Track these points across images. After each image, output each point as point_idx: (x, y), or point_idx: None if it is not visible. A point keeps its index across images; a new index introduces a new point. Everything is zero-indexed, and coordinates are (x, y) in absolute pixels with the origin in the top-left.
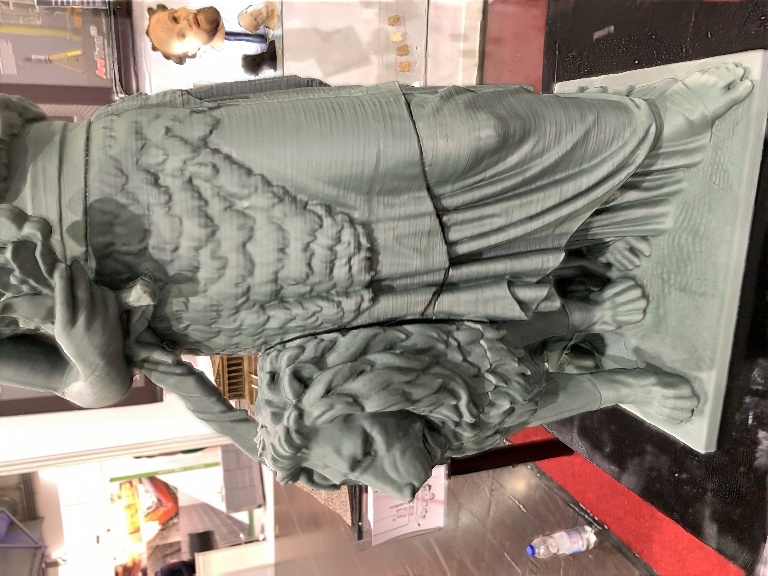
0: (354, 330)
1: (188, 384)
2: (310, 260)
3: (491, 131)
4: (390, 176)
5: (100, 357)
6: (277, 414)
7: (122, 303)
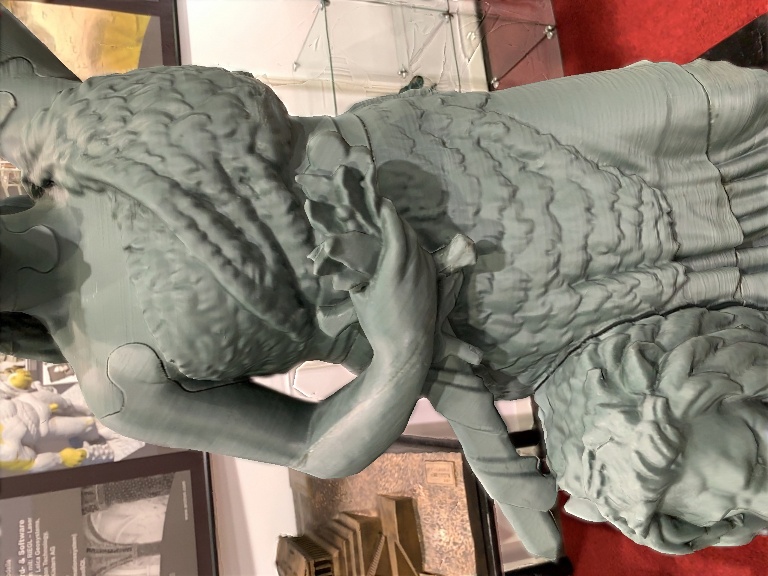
0: (673, 313)
1: (482, 408)
2: (619, 222)
3: (767, 79)
4: (679, 129)
5: (422, 331)
6: (630, 412)
7: (438, 265)
